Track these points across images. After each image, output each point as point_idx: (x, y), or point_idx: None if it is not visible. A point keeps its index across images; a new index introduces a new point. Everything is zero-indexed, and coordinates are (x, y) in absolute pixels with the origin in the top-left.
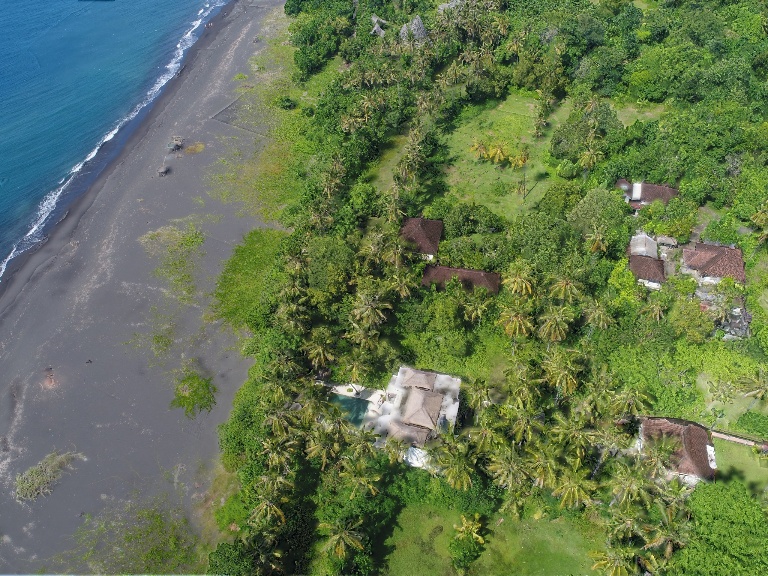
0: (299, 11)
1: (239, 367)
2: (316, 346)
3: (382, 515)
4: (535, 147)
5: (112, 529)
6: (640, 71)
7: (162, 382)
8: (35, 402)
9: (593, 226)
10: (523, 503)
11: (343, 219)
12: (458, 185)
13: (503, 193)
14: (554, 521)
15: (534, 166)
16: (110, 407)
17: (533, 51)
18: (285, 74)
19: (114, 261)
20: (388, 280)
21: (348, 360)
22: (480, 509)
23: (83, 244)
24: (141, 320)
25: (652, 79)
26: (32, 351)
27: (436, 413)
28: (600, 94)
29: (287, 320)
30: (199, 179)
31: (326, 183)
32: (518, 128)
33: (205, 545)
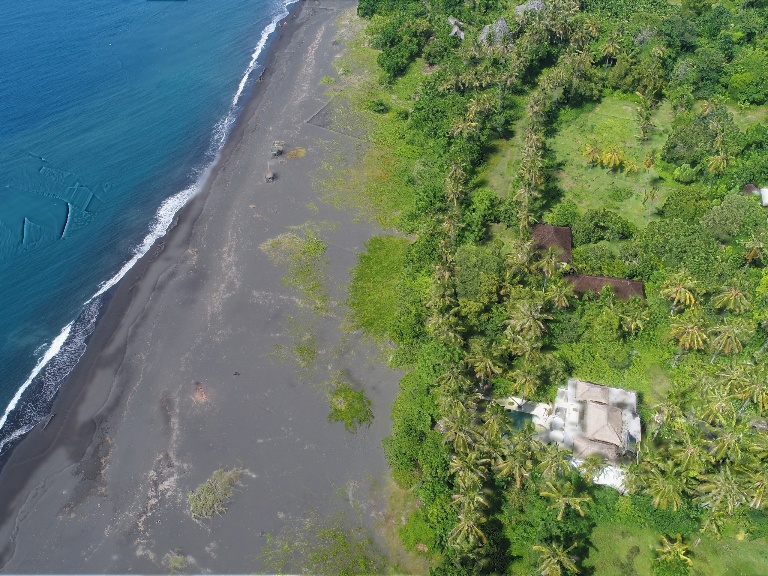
0: (372, 13)
1: (388, 379)
2: (484, 359)
3: (579, 535)
4: (642, 151)
5: (296, 549)
6: (741, 73)
7: (315, 395)
8: (190, 416)
9: (734, 233)
10: (723, 523)
11: (471, 226)
12: (573, 190)
13: (621, 198)
14: (754, 541)
15: (646, 170)
16: (267, 421)
17: (626, 53)
18: (371, 77)
19: (239, 269)
20: (532, 289)
21: (521, 373)
22: (681, 529)
23: (203, 252)
24: (280, 330)
25: (754, 81)
26: (175, 363)
27: (620, 429)
28: (696, 96)
29: (446, 331)
30: (307, 185)
31: (453, 189)
32: (621, 131)
33: (395, 566)
